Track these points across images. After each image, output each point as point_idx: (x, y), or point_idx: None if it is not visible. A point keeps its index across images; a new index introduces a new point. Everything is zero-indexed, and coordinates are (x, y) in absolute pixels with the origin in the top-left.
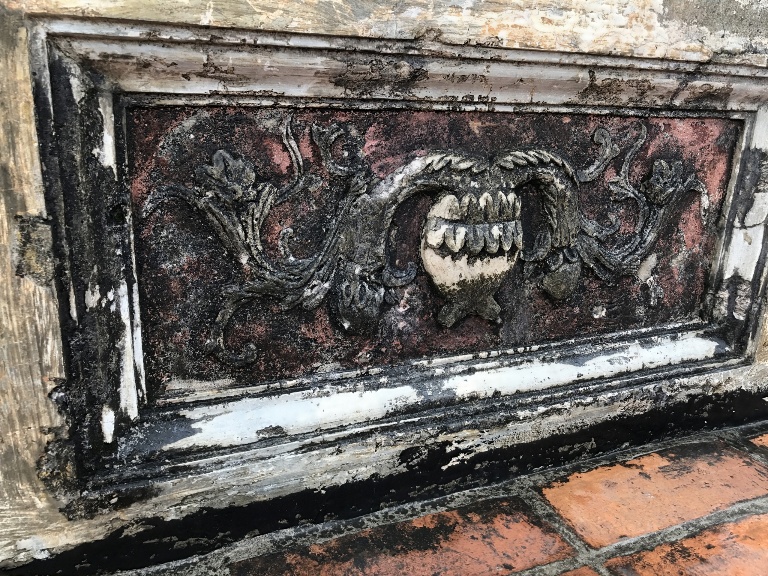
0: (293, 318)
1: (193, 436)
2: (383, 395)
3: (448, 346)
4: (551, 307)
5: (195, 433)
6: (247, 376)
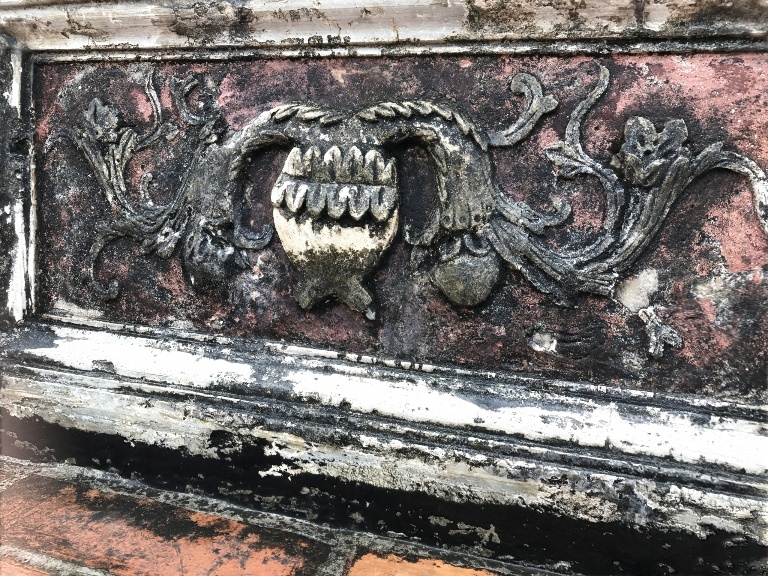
0: (152, 264)
1: (49, 349)
2: (218, 365)
3: (312, 335)
4: (457, 317)
5: (52, 347)
6: (112, 313)
